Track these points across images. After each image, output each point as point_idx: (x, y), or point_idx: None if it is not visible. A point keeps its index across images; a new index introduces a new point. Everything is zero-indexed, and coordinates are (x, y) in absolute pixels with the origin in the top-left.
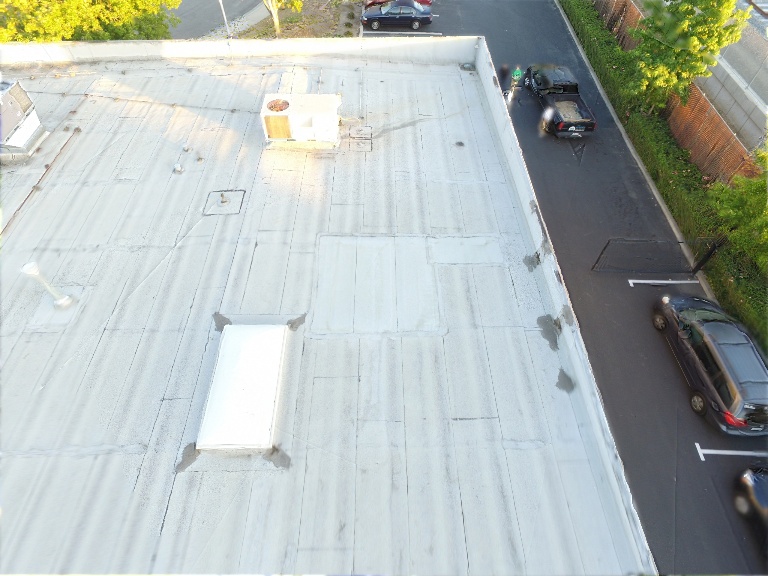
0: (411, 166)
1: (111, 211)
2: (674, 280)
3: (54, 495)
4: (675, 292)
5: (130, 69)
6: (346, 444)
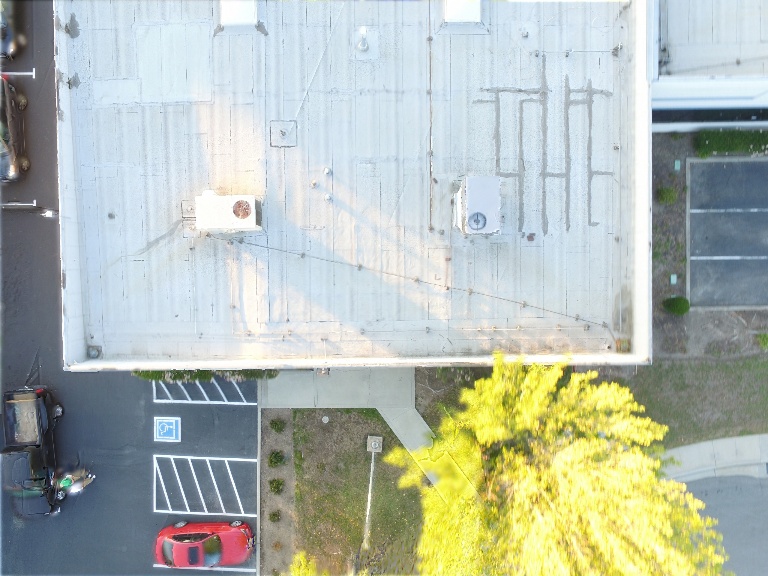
0: (151, 183)
1: (364, 128)
2: (1, 207)
3: None
4: (4, 195)
5: (425, 339)
6: None
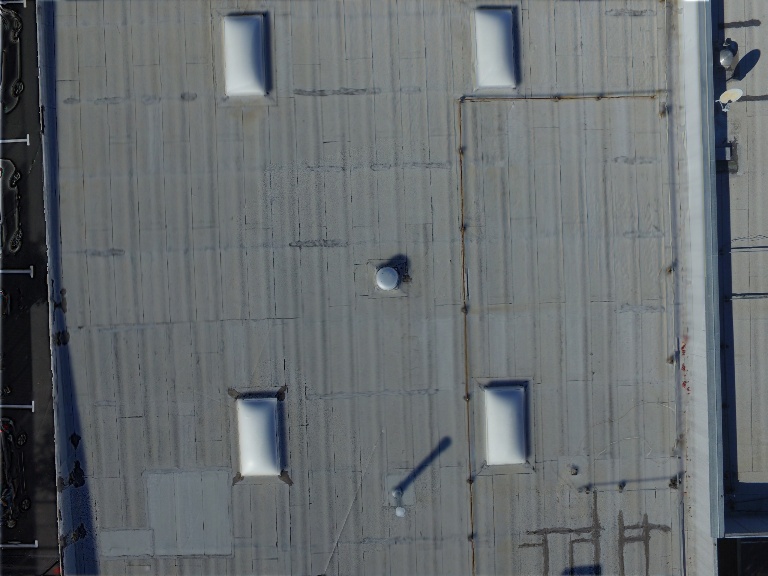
0: None
1: None
2: None
3: (346, 374)
4: (3, 535)
5: None
6: (200, 402)
